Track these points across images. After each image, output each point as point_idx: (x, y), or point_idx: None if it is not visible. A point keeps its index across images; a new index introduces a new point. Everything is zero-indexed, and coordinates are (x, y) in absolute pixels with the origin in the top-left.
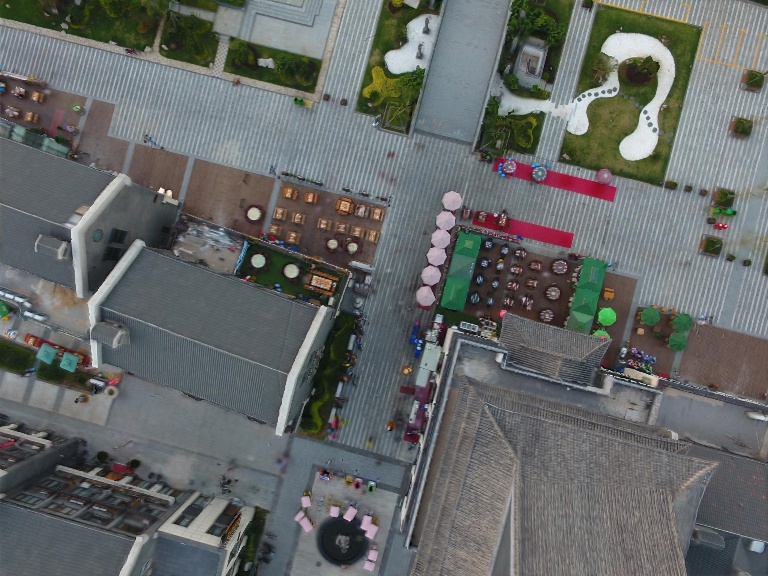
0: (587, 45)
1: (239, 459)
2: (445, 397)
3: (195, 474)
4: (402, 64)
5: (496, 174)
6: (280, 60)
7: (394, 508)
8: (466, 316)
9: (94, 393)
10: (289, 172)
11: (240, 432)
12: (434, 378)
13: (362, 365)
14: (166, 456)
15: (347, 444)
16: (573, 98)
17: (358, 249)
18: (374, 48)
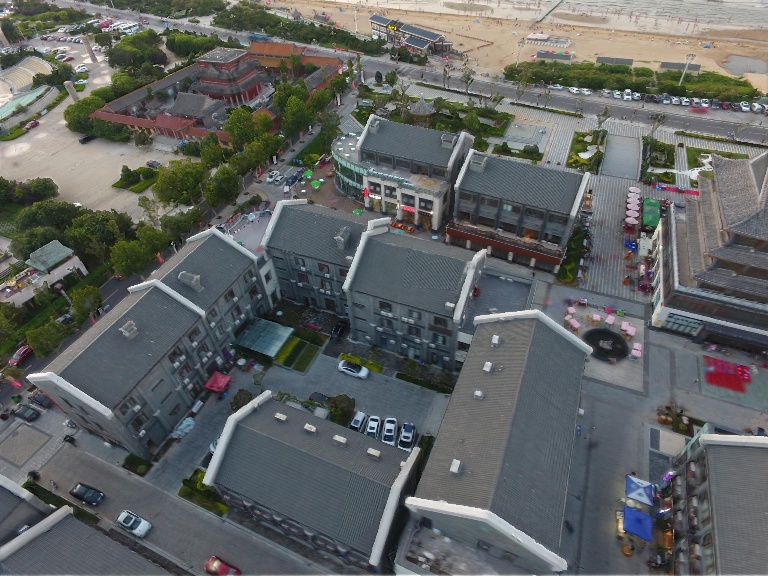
0: (687, 156)
1: None
2: (673, 222)
3: None
4: (587, 156)
5: (655, 189)
6: (526, 146)
7: (643, 329)
8: None
9: None
10: None
11: None
12: (651, 258)
13: (594, 254)
14: None
15: (594, 290)
16: (688, 170)
17: None
18: (571, 151)
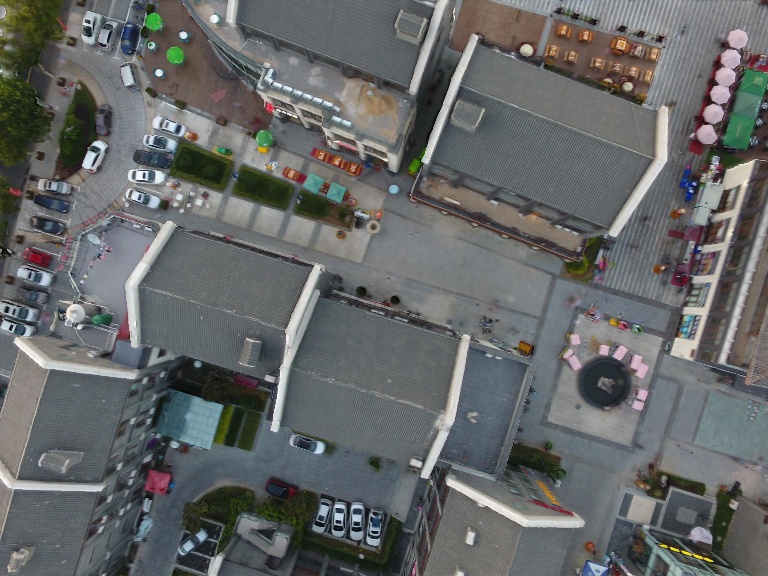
0: None
1: (499, 300)
2: None
3: (453, 314)
4: None
5: None
6: None
7: (658, 352)
8: (740, 160)
9: (356, 227)
10: (562, 10)
11: (501, 273)
12: (709, 220)
13: None
14: (423, 295)
15: (612, 287)
16: None
17: (632, 89)
18: None
